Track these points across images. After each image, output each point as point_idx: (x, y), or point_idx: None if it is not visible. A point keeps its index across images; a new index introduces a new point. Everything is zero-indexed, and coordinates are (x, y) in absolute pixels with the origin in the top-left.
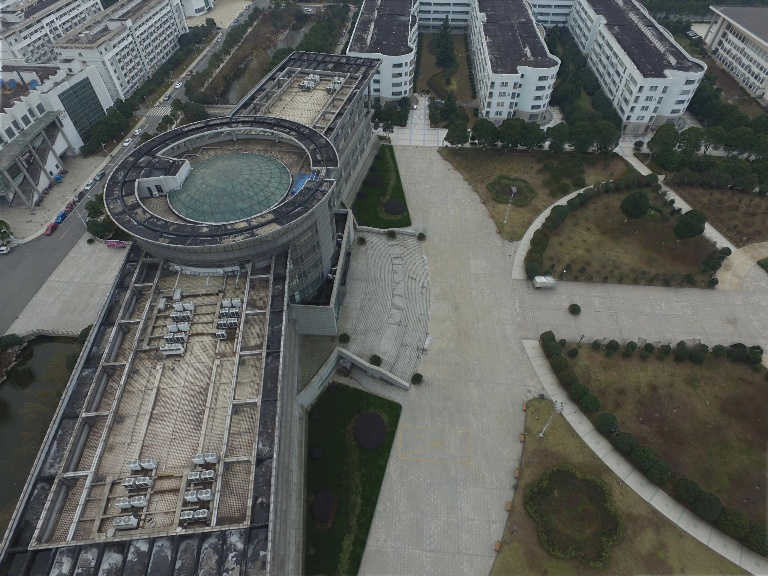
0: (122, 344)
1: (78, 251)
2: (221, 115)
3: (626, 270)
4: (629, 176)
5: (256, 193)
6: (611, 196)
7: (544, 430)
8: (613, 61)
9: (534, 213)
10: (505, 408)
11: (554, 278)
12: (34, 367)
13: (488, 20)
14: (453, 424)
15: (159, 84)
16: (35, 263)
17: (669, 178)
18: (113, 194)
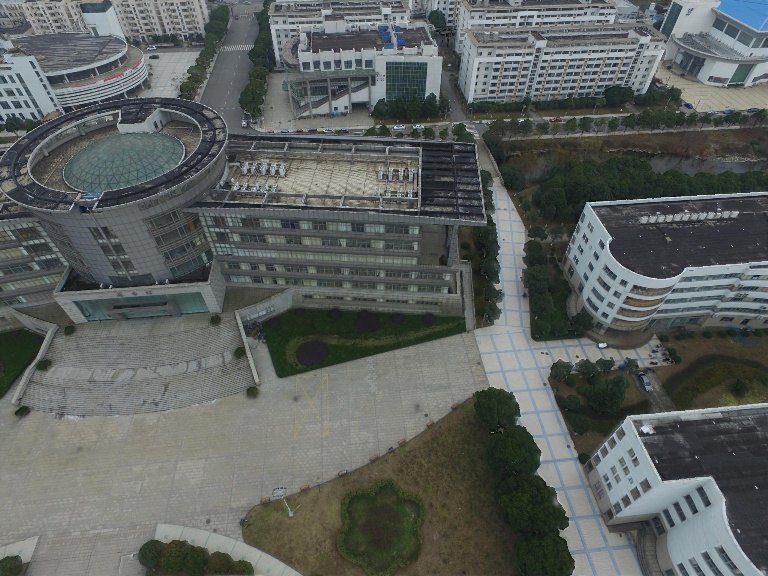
0: None
1: None
2: None
3: None
4: None
5: (88, 172)
6: None
7: None
8: None
9: (318, 571)
10: None
11: None
12: None
13: None
14: None
15: (515, 110)
16: None
17: None
18: None
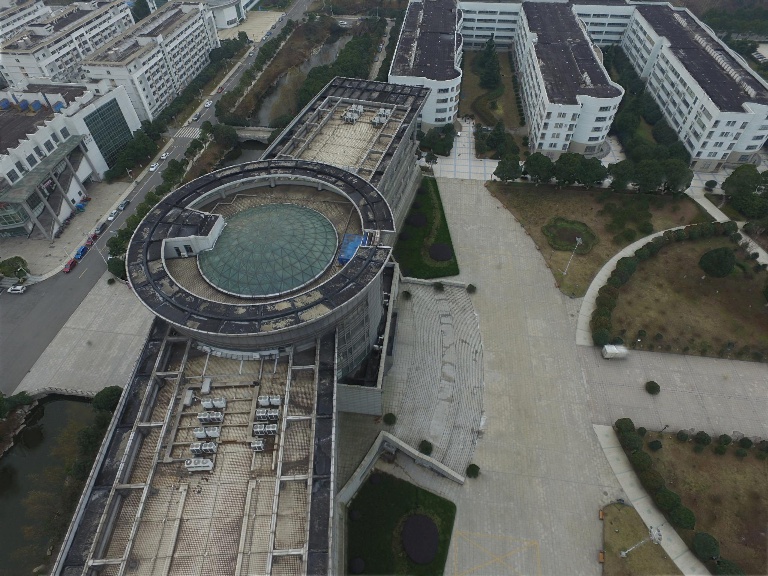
0: (140, 451)
1: (97, 293)
2: (252, 138)
3: (708, 339)
4: (705, 224)
5: (299, 259)
6: (683, 246)
7: (627, 548)
8: (680, 89)
9: (597, 264)
10: (578, 515)
11: (625, 346)
12: (45, 426)
13: (539, 40)
14: (517, 533)
15: (188, 102)
16: (51, 305)
17: (758, 233)
18: (136, 258)
